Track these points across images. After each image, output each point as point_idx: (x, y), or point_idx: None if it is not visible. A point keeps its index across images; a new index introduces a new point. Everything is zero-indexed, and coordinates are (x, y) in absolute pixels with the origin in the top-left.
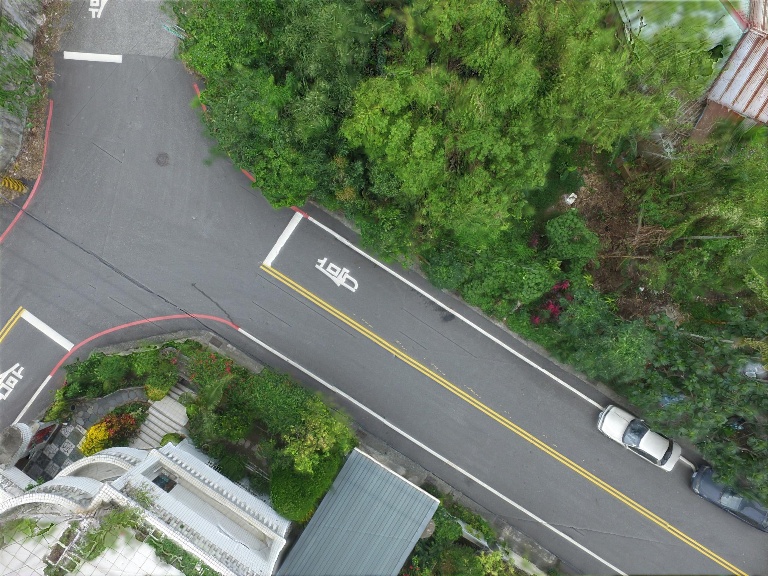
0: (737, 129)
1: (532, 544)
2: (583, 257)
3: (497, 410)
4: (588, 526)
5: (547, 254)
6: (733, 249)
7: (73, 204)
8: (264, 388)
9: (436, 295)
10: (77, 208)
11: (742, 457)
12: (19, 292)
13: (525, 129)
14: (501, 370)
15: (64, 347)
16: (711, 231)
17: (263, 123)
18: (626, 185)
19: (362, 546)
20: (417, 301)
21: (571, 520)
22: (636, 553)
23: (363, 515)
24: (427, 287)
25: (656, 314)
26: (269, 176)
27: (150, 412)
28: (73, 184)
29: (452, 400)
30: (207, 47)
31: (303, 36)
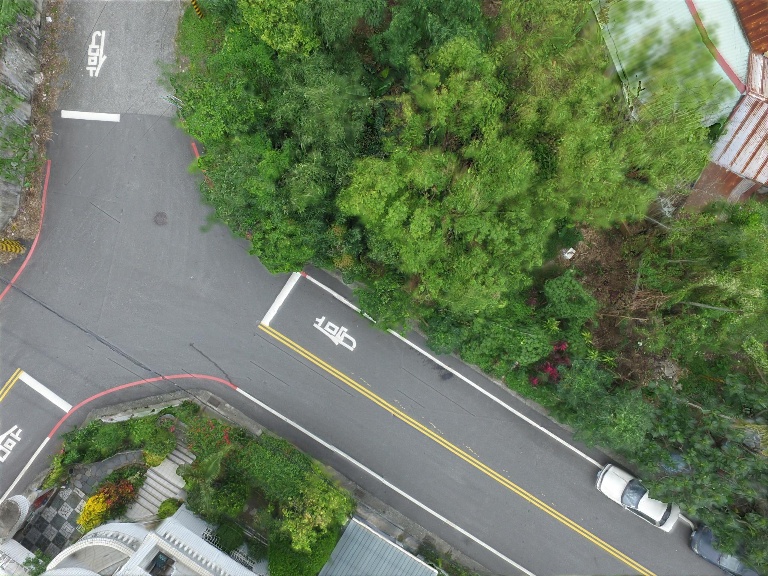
0: (735, 189)
1: None
2: (581, 317)
3: (495, 469)
4: None
5: (545, 312)
6: (731, 317)
7: (71, 264)
8: (262, 456)
9: (434, 353)
10: (75, 269)
11: (741, 526)
12: (17, 354)
13: (522, 215)
14: (499, 428)
15: (62, 409)
16: (709, 299)
17: (260, 196)
18: (624, 240)
19: None
20: (415, 359)
21: None
22: None
23: None
24: None
25: None
26: (267, 247)
27: (148, 475)
28: (71, 244)
29: (450, 459)
30: (204, 116)
31: (301, 103)
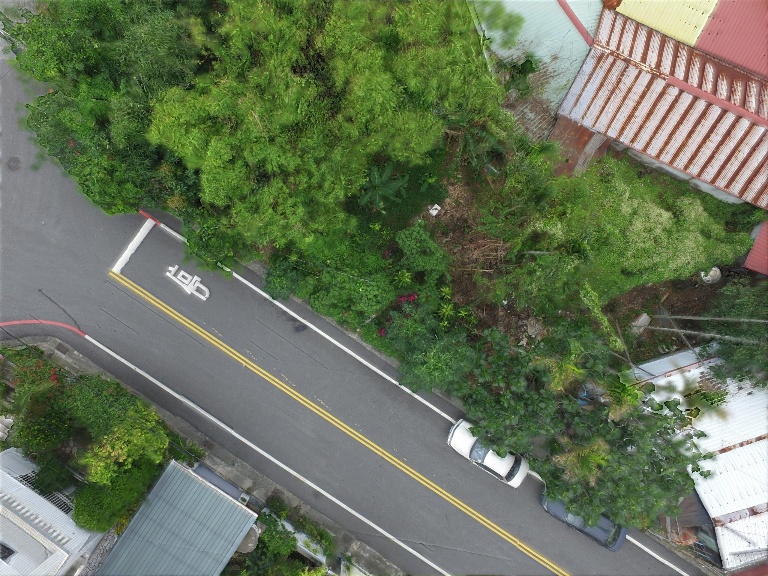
0: (589, 144)
1: (380, 560)
2: (434, 269)
3: (347, 422)
4: (437, 542)
5: (401, 265)
6: (564, 264)
7: None
8: (87, 397)
9: (289, 305)
10: None
11: None
12: None
13: (313, 141)
14: (353, 382)
15: None
16: (542, 246)
17: (82, 129)
18: (490, 197)
19: (176, 560)
20: (269, 311)
21: (420, 536)
22: (486, 570)
23: (178, 528)
24: None
25: (488, 329)
26: (92, 182)
27: None
28: None
29: (301, 412)
30: (36, 52)
31: (139, 43)
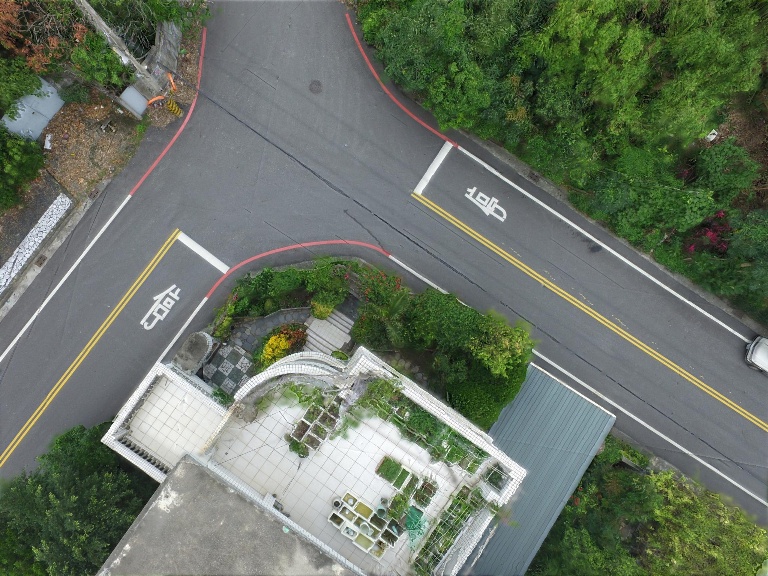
0: None
1: (679, 475)
2: (734, 188)
3: (644, 341)
4: (734, 458)
5: (695, 186)
6: None
7: (228, 129)
8: (436, 304)
9: (583, 226)
10: (232, 133)
11: None
12: (175, 214)
13: None
14: (648, 301)
15: (220, 270)
16: None
17: (449, 36)
18: (766, 123)
19: (540, 459)
20: (565, 232)
21: None
22: None
23: (540, 429)
24: (574, 218)
25: None
26: (449, 91)
27: (308, 334)
28: (228, 109)
29: (600, 330)
30: None
31: None
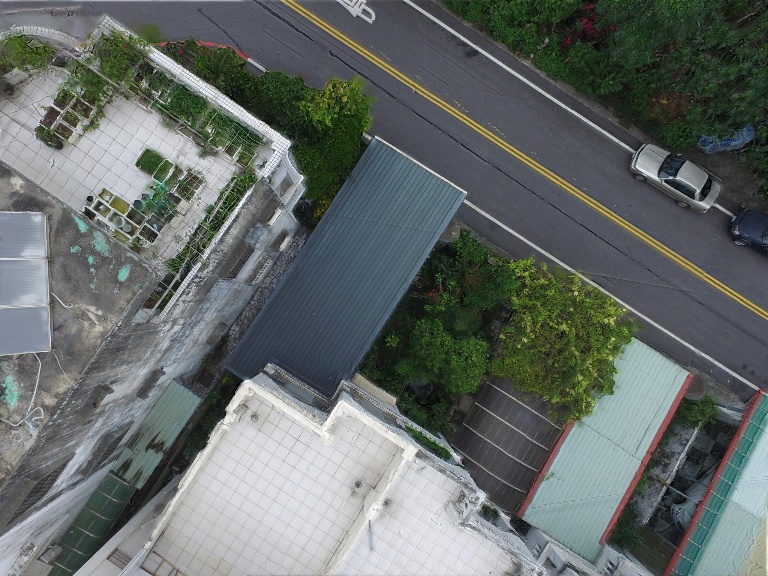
0: None
1: None
2: None
3: (523, 150)
4: (620, 275)
5: None
6: None
7: None
8: (277, 80)
9: (459, 29)
10: None
11: None
12: None
13: None
14: (528, 109)
15: None
16: None
17: None
18: None
19: (383, 237)
20: (438, 35)
21: (601, 268)
22: (670, 304)
23: (384, 205)
24: (449, 21)
25: None
26: None
27: None
28: None
29: (475, 138)
30: None
31: None
